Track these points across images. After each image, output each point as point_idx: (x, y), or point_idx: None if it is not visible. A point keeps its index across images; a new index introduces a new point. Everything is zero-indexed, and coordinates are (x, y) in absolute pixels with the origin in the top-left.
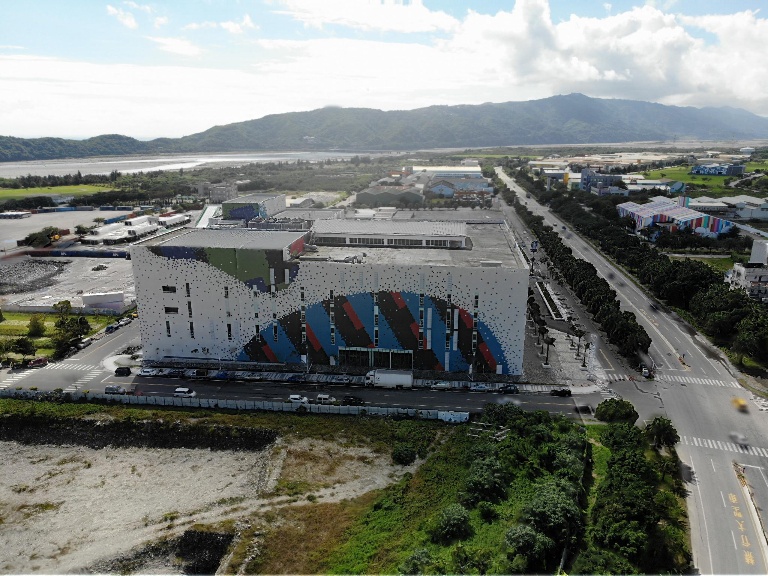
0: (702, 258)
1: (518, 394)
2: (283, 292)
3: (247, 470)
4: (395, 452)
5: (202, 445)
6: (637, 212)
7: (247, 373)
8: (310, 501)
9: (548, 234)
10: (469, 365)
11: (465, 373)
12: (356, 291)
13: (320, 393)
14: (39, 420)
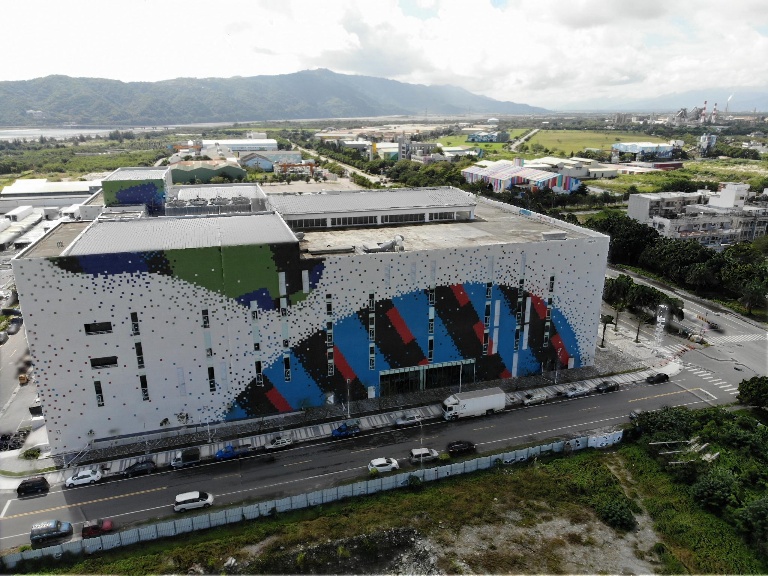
0: (580, 215)
1: (619, 390)
2: (299, 306)
3: None
4: (611, 516)
5: None
6: (490, 175)
7: (258, 438)
8: None
9: None
10: (540, 364)
11: (537, 375)
12: (406, 290)
13: (399, 446)
14: None
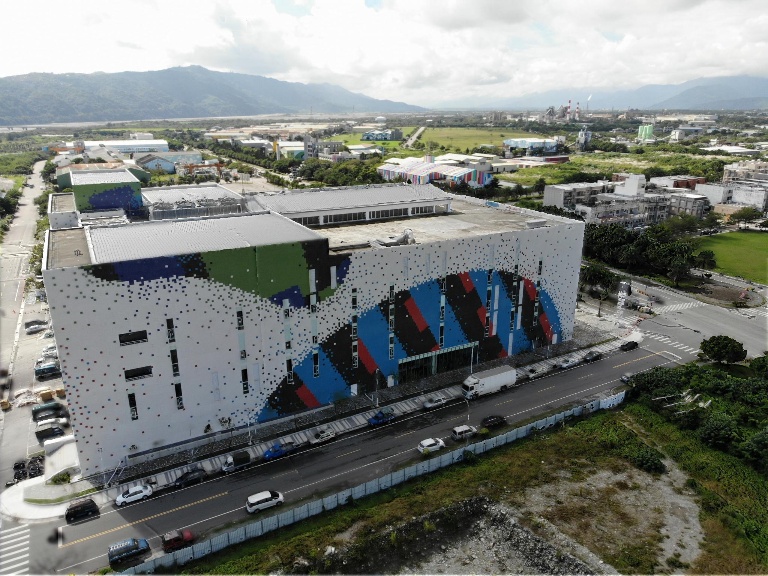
0: None
1: (602, 359)
2: (327, 302)
3: (503, 571)
4: (646, 463)
5: (389, 568)
6: (408, 172)
7: (298, 435)
8: (681, 568)
9: None
10: (531, 342)
11: (528, 352)
12: (421, 281)
13: (436, 427)
14: None
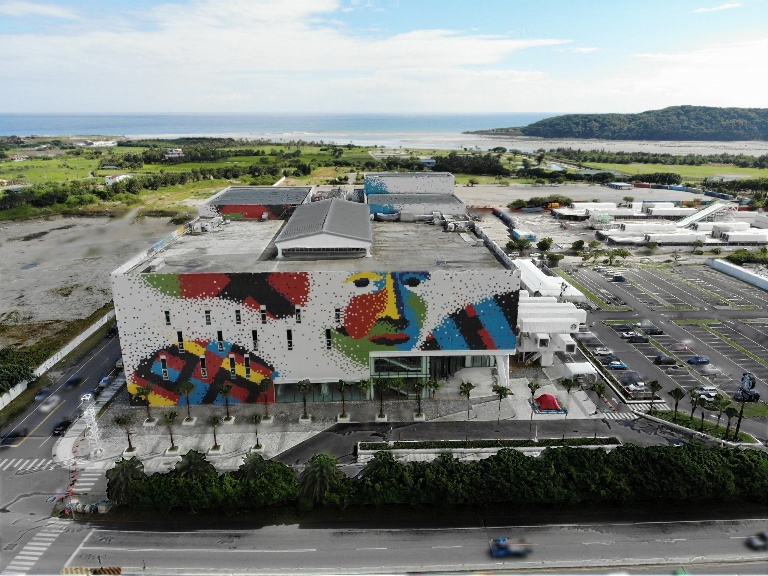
0: None
1: (83, 403)
2: None
3: None
4: None
5: None
6: None
7: None
8: None
9: None
10: None
11: None
12: None
13: None
14: None
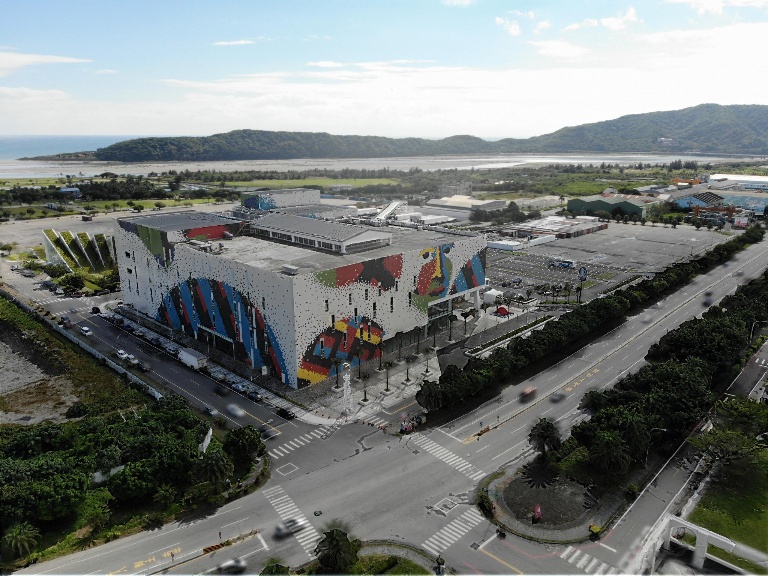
0: None
1: (256, 402)
2: (170, 268)
3: None
4: None
5: (44, 367)
6: None
7: (145, 330)
8: None
9: (680, 265)
10: (264, 366)
11: (261, 373)
12: (201, 276)
13: (146, 355)
14: (11, 326)
